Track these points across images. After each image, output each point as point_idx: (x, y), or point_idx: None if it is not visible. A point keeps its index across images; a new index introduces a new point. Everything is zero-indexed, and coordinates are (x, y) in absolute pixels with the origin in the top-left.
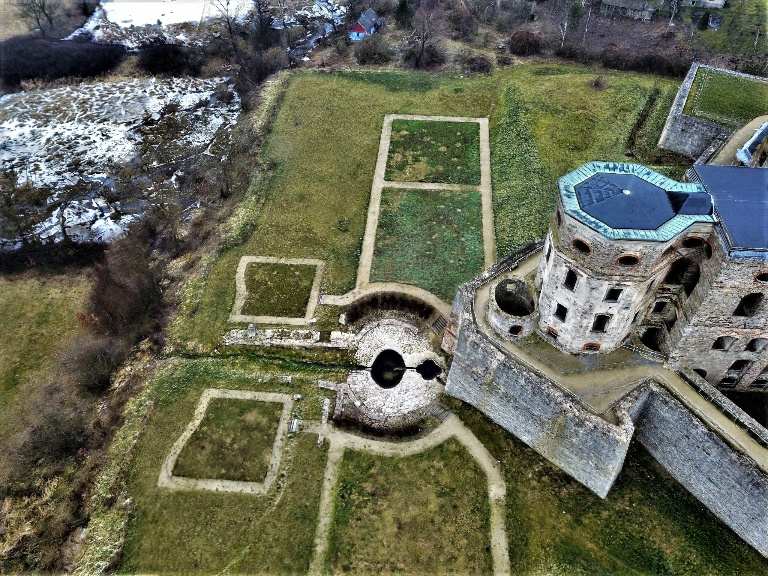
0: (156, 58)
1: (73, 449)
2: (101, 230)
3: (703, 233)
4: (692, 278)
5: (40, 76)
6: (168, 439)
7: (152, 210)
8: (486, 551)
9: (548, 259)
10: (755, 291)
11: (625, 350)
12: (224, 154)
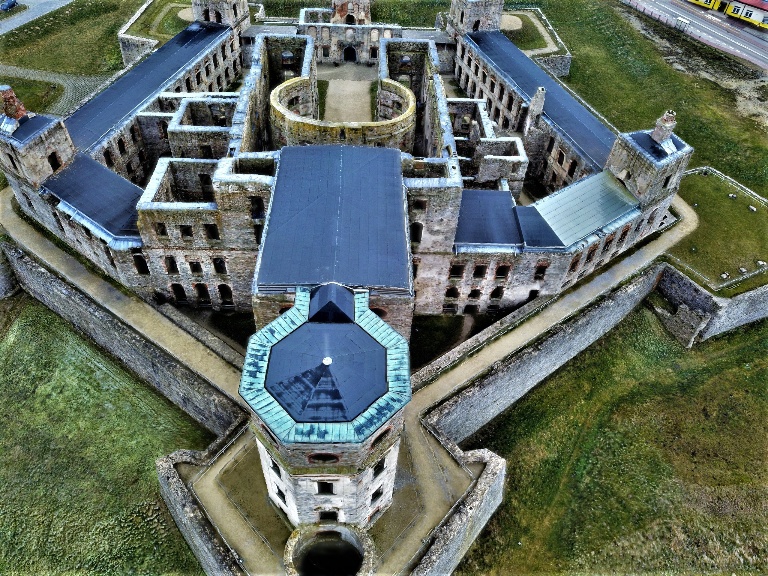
0: None
1: None
2: None
3: None
4: None
5: None
6: None
7: None
8: None
9: (328, 492)
10: None
11: None
12: None
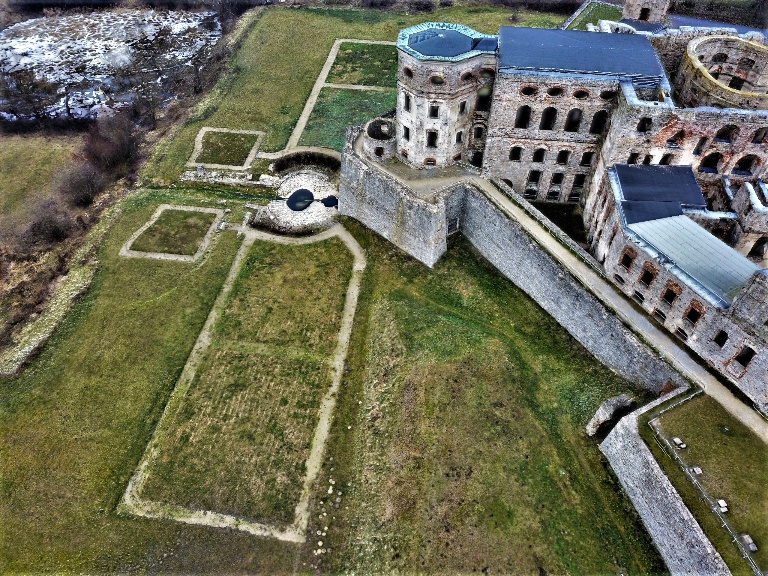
0: None
1: (62, 238)
2: (97, 111)
3: (492, 65)
4: None
5: (59, 5)
6: (130, 231)
7: (138, 97)
8: (342, 296)
9: None
10: (523, 104)
11: (456, 167)
12: (202, 65)
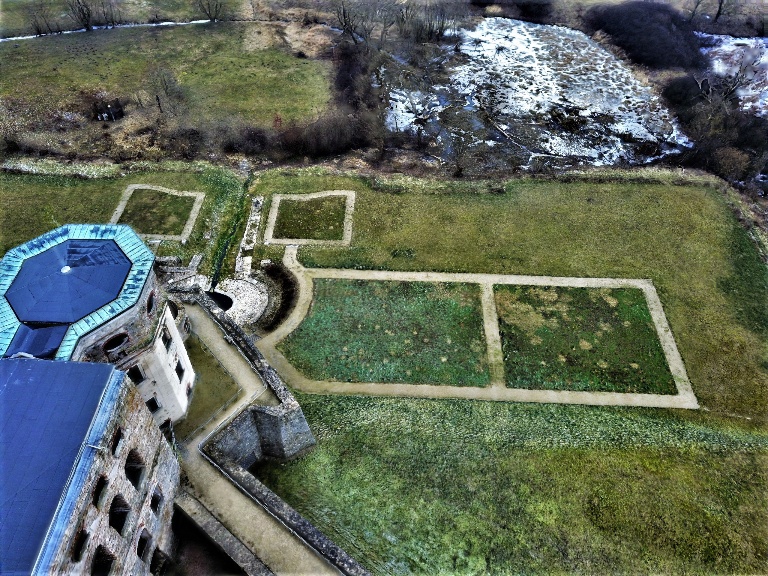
0: (680, 84)
1: None
2: (400, 118)
3: None
4: None
5: (613, 36)
6: (165, 183)
7: None
8: None
9: None
10: None
11: None
12: None
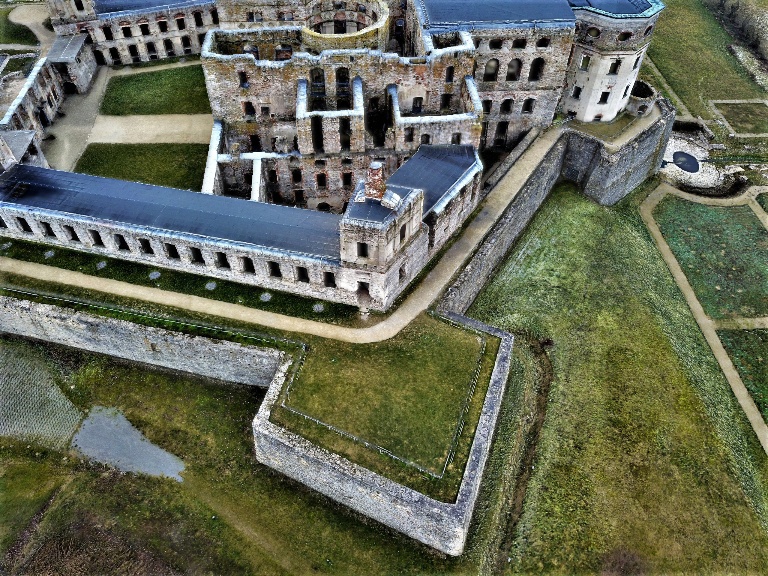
0: None
1: None
2: None
3: None
4: None
5: None
6: None
7: None
8: None
9: None
10: None
11: None
12: None
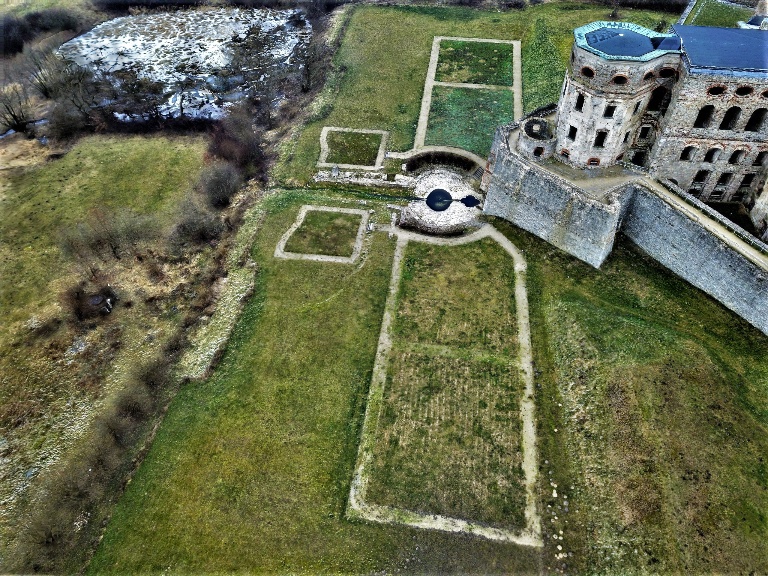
0: None
1: (208, 239)
2: (208, 111)
3: (674, 64)
4: (667, 105)
5: (144, 4)
6: (279, 232)
7: (249, 97)
8: (511, 297)
9: (564, 94)
10: (708, 104)
11: (618, 167)
12: (301, 64)
